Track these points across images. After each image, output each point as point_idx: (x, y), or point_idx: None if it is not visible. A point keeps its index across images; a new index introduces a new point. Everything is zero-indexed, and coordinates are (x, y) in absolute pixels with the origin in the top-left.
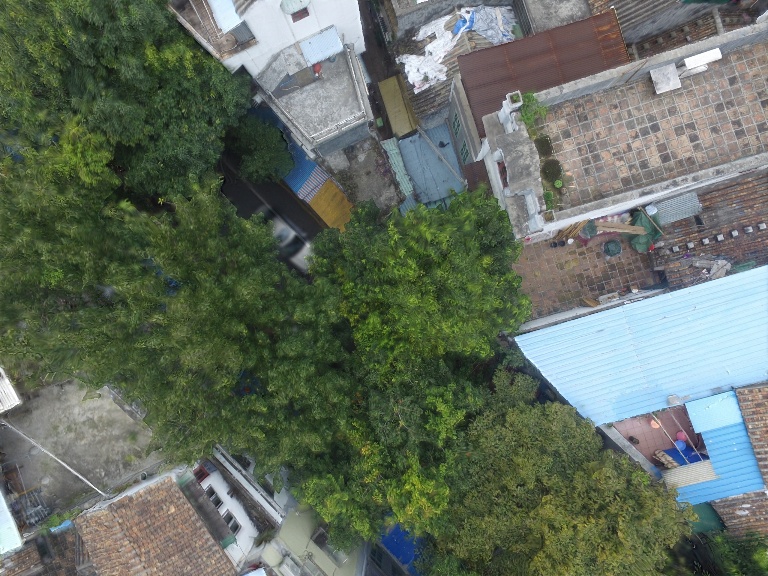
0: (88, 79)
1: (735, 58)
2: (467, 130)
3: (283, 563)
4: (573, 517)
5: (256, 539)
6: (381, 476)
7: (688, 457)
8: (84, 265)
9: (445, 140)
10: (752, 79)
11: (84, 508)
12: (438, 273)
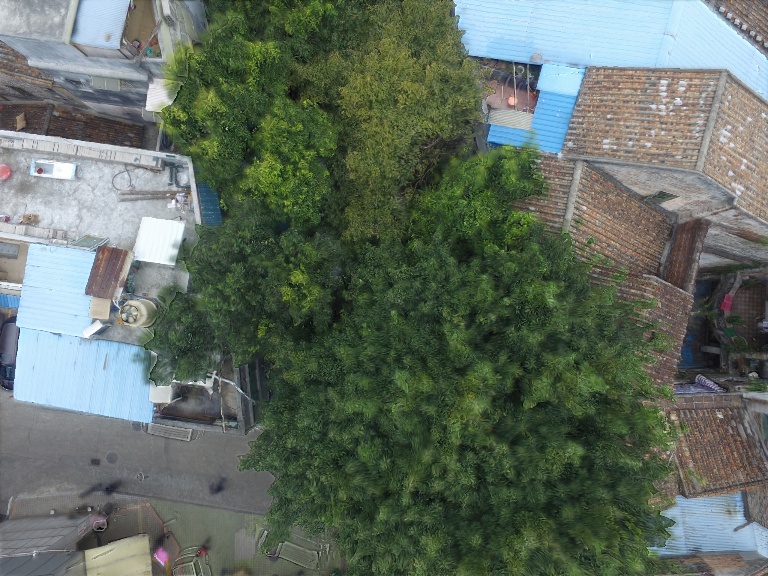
0: None
1: None
2: None
3: None
4: None
5: None
6: None
7: None
8: None
9: None
10: None
11: None
12: None
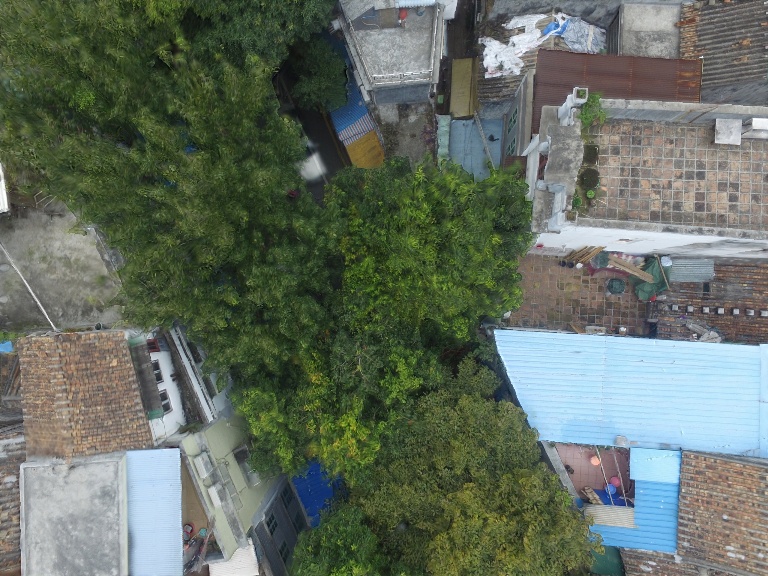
0: None
1: None
2: (521, 127)
3: (199, 455)
4: (487, 511)
5: (182, 427)
6: (321, 411)
7: (614, 499)
8: (118, 97)
9: (496, 135)
10: None
11: None
12: (448, 226)
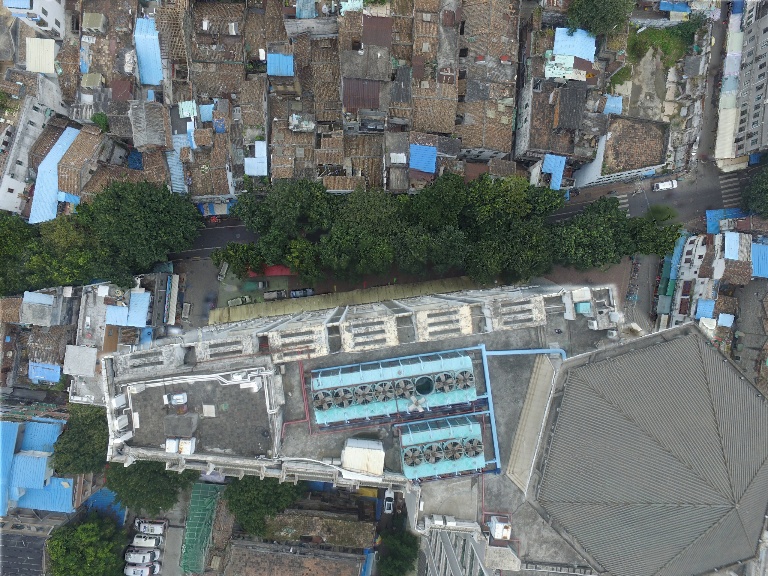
0: None
1: None
2: None
3: None
4: None
5: None
6: None
7: None
8: None
9: None
10: None
11: (1, 324)
12: None
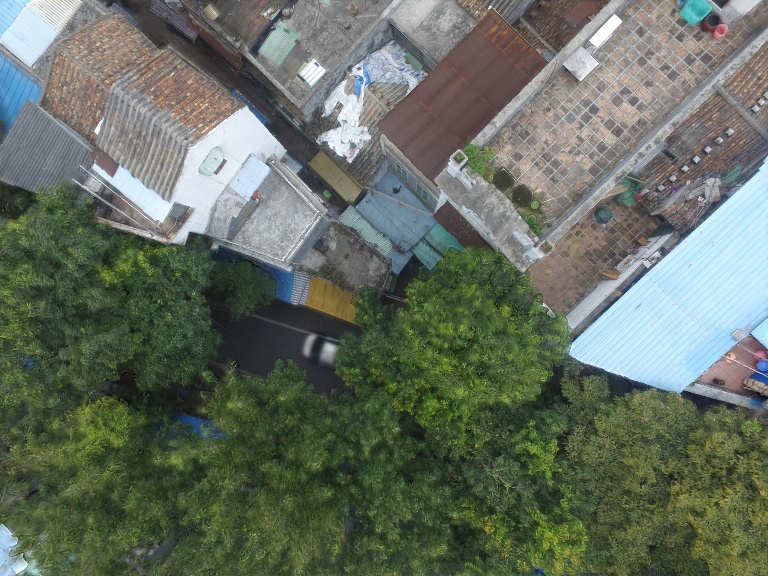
0: (62, 325)
1: (631, 11)
2: (416, 177)
3: None
4: (709, 494)
5: None
6: (514, 542)
7: None
8: (156, 515)
9: (396, 185)
10: (657, 21)
11: None
12: (478, 358)
